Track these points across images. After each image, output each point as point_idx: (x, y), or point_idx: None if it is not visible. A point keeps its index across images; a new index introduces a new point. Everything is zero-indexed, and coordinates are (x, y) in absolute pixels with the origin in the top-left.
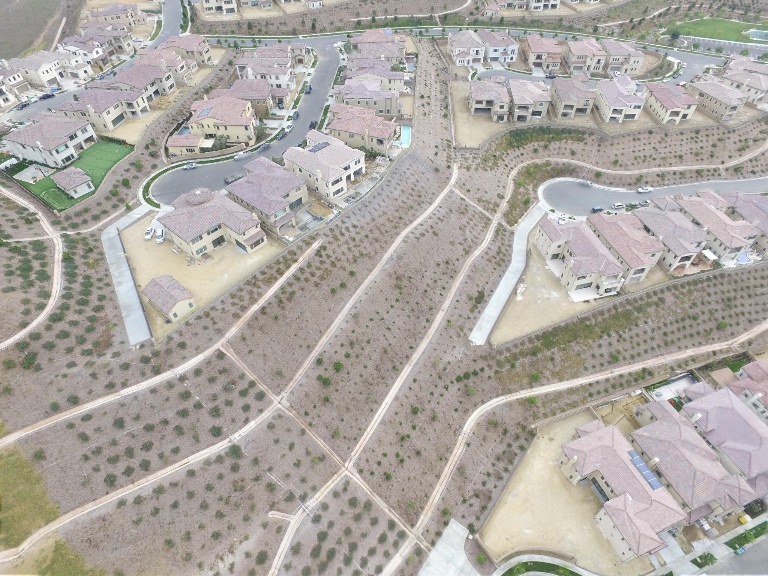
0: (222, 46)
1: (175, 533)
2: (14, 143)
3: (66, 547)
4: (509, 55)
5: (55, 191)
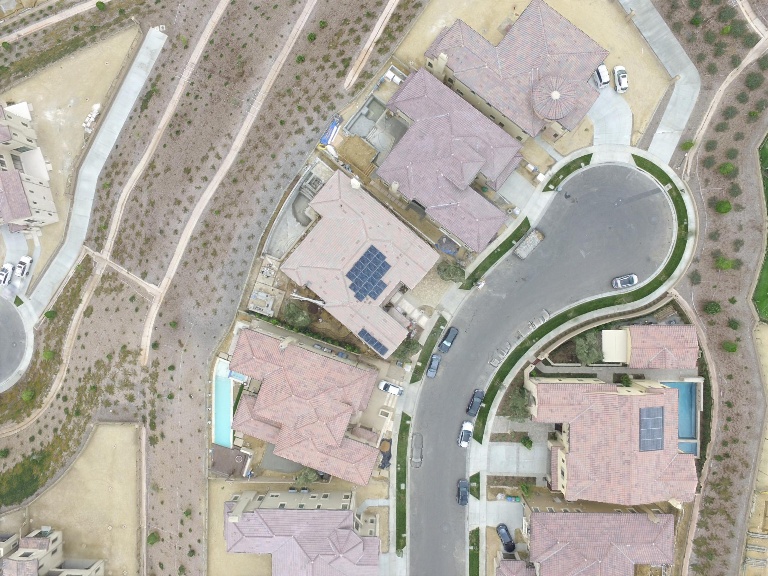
0: None
1: None
2: None
3: None
4: None
5: None
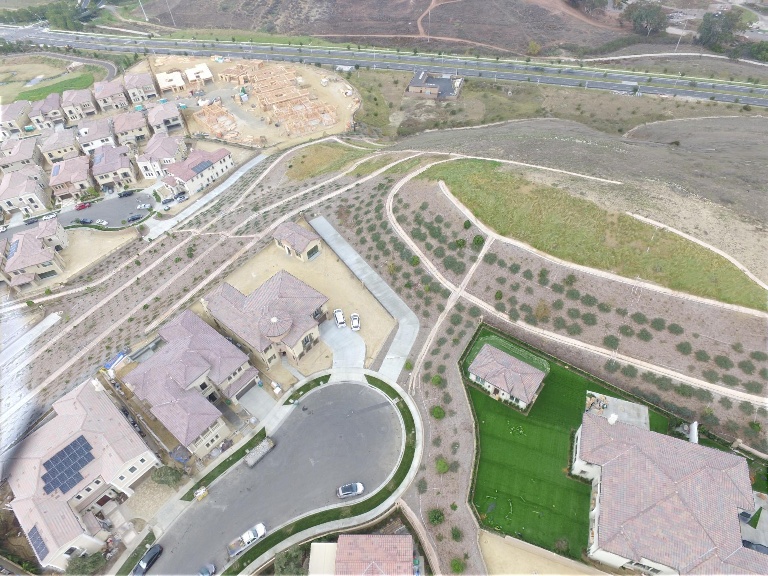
0: None
1: None
2: None
3: None
4: None
5: None
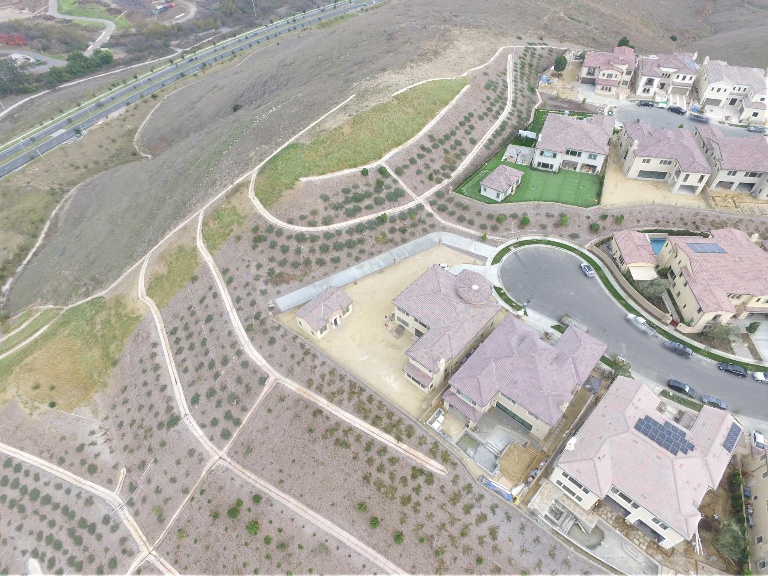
0: None
1: (130, 391)
2: None
3: (137, 322)
4: None
5: None
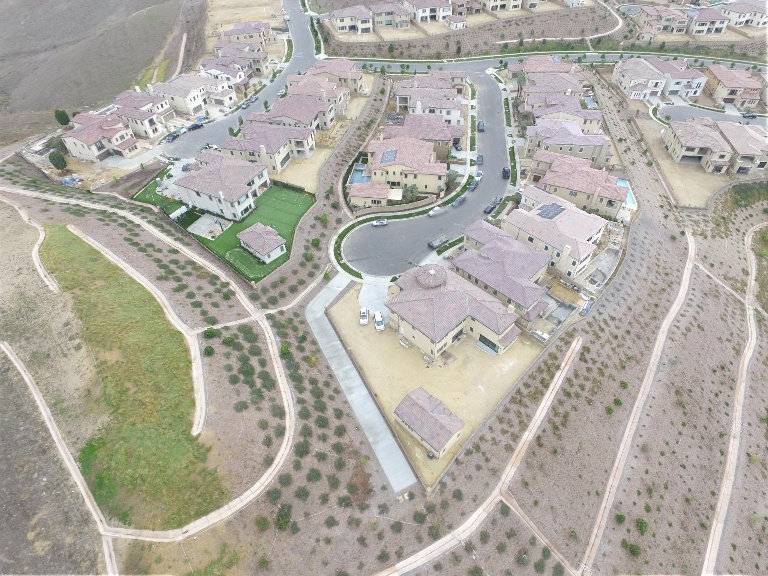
0: (368, 71)
1: None
2: (187, 189)
3: None
4: (693, 89)
5: (240, 252)
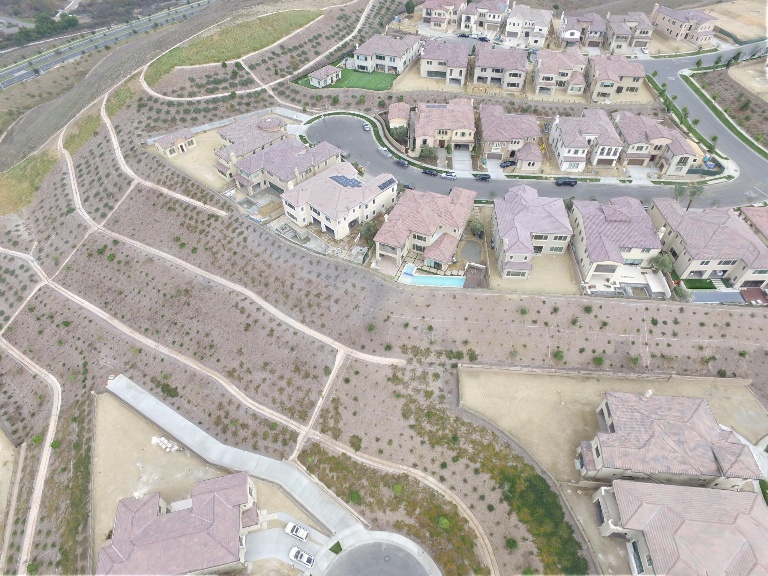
0: (659, 98)
1: None
2: None
3: (54, 163)
4: None
5: None
